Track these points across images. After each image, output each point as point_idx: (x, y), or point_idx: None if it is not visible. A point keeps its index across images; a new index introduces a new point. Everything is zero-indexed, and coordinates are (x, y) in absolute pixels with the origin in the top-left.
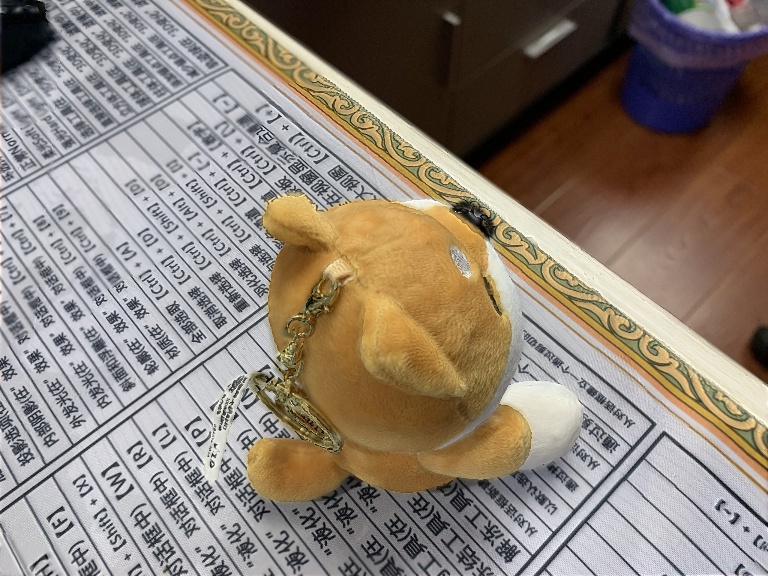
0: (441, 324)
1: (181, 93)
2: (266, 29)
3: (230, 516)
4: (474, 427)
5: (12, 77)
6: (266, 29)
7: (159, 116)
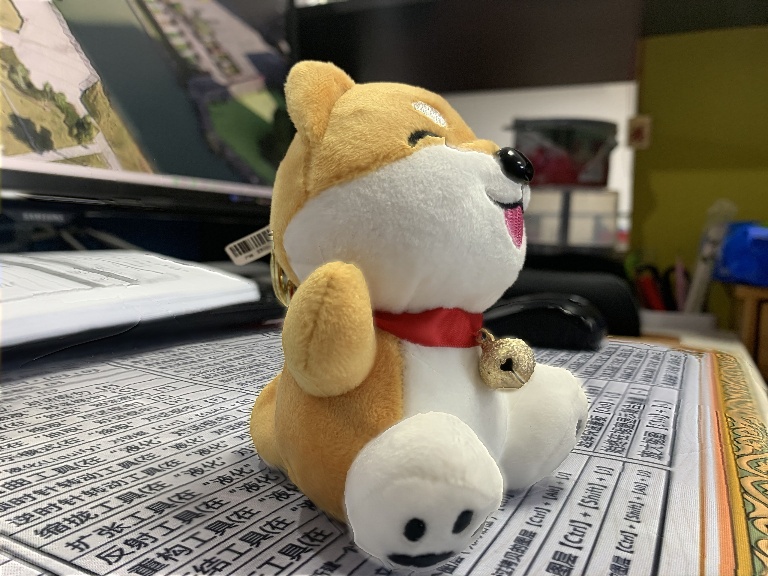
0: (355, 99)
1: (617, 380)
2: (757, 399)
3: (234, 442)
4: (312, 228)
5: (539, 349)
6: (757, 399)
7: (583, 379)
